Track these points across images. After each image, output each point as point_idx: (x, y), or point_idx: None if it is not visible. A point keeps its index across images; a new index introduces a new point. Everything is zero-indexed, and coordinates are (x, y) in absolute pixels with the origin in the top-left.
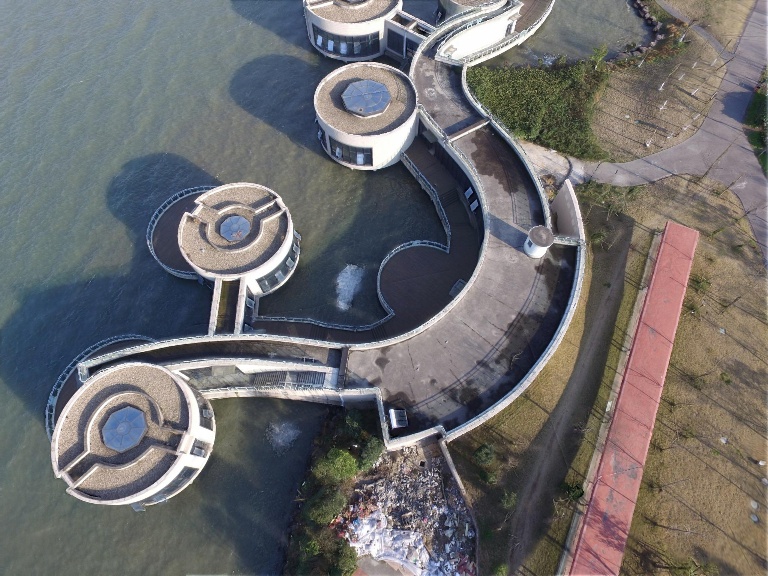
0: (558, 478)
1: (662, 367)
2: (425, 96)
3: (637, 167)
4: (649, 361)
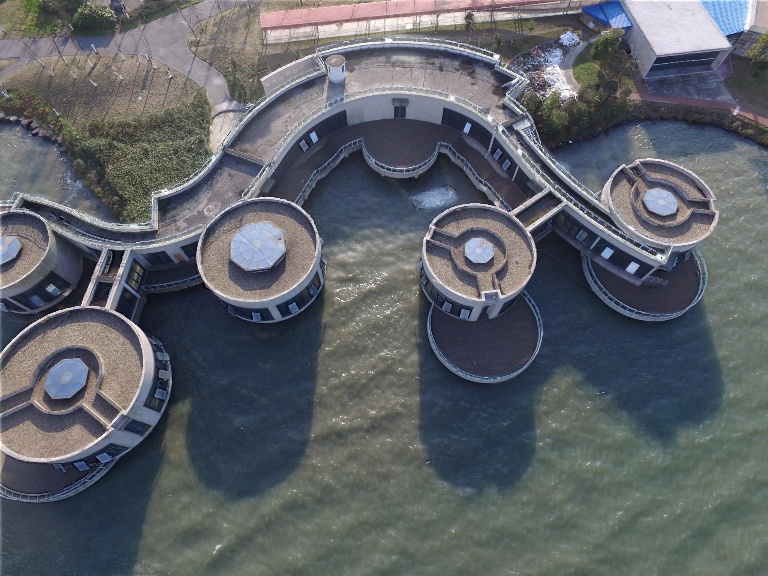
0: (466, 32)
1: (374, 4)
2: (218, 211)
3: (199, 76)
4: (375, 9)
